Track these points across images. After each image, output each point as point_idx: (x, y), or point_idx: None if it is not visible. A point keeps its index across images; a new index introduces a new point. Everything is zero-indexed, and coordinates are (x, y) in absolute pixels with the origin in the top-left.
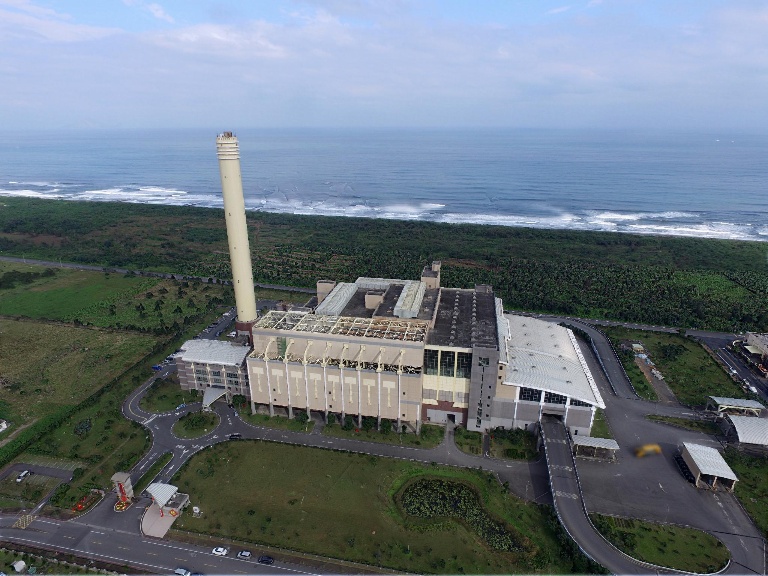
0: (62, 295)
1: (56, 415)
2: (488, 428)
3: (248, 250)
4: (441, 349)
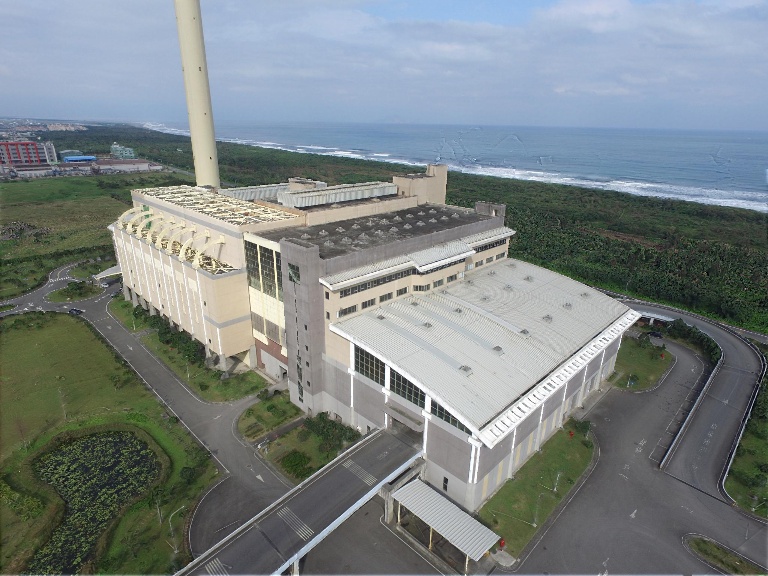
0: None
1: None
2: (311, 408)
3: (206, 119)
4: (259, 242)
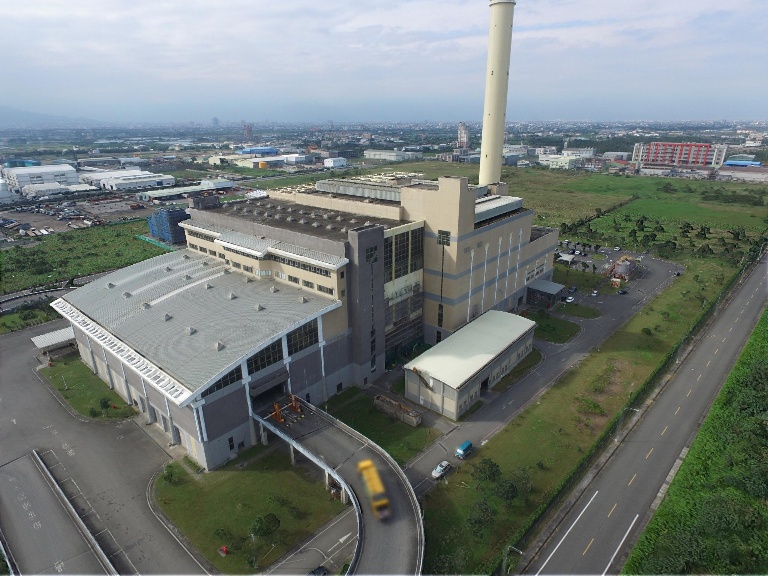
0: (685, 209)
1: None
2: None
3: (490, 120)
4: None
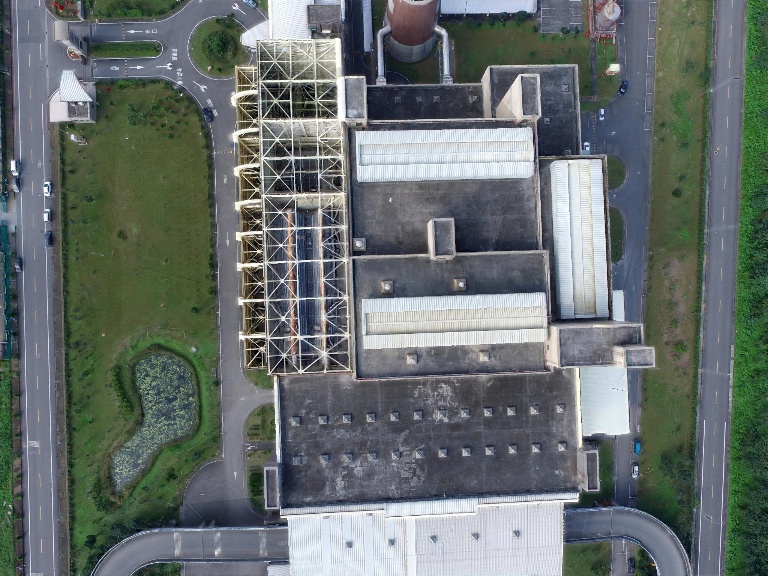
0: None
1: None
2: None
3: None
4: None
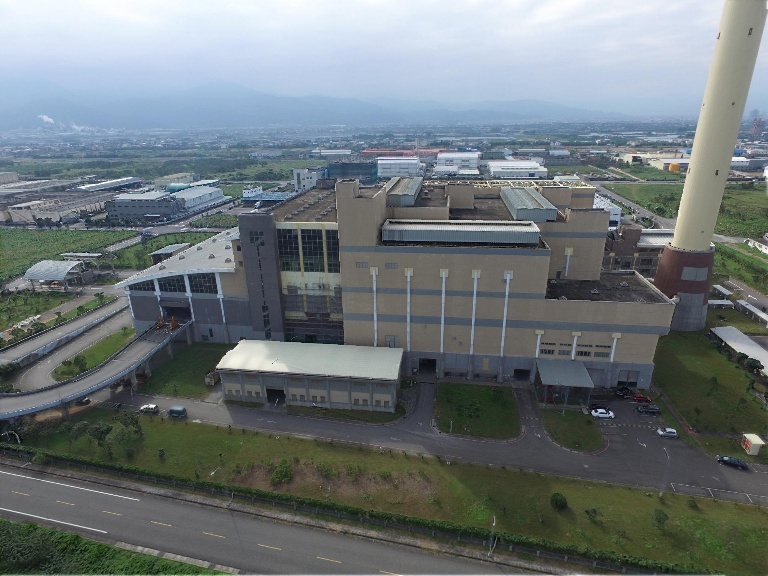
0: None
1: (758, 264)
2: None
3: (703, 113)
4: None
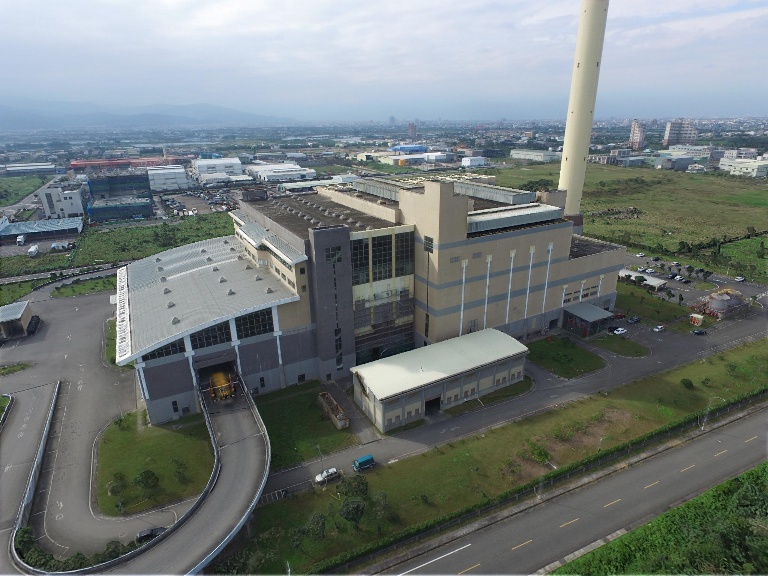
0: None
1: None
2: None
3: (572, 118)
4: None
